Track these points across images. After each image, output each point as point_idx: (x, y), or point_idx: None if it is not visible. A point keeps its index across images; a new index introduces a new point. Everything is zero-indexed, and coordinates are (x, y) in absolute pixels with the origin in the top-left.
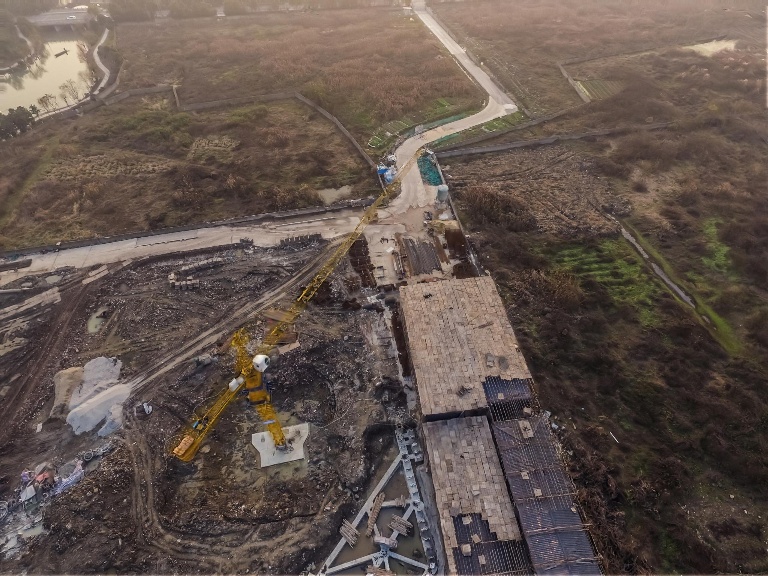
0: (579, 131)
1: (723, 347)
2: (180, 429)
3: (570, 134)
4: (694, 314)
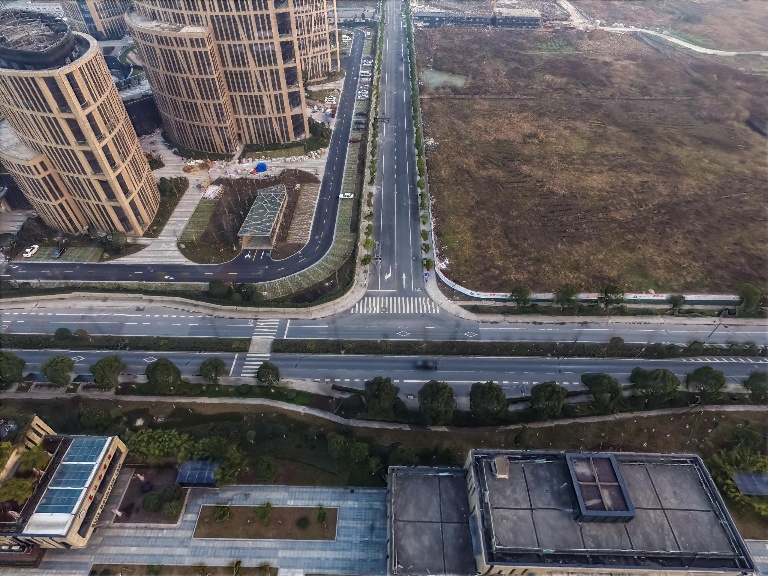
0: (678, 58)
1: (516, 49)
2: (497, 7)
3: (671, 54)
4: (531, 51)
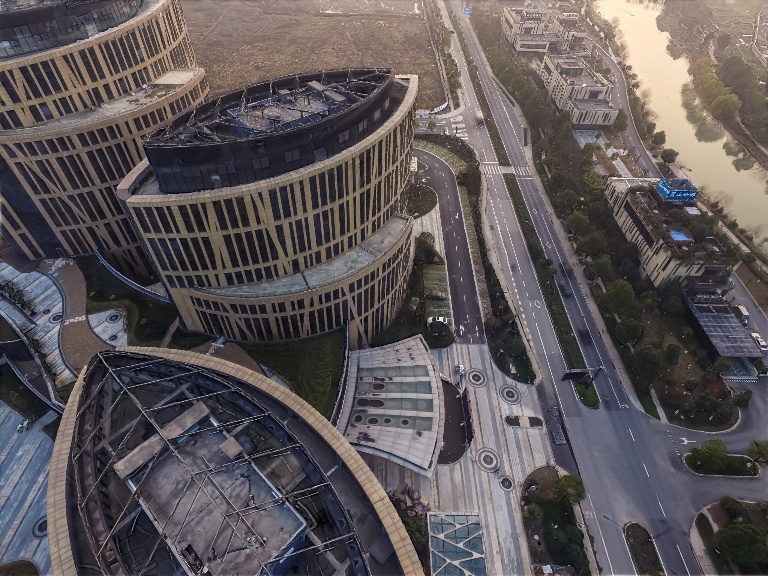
0: None
1: None
2: None
3: None
4: None
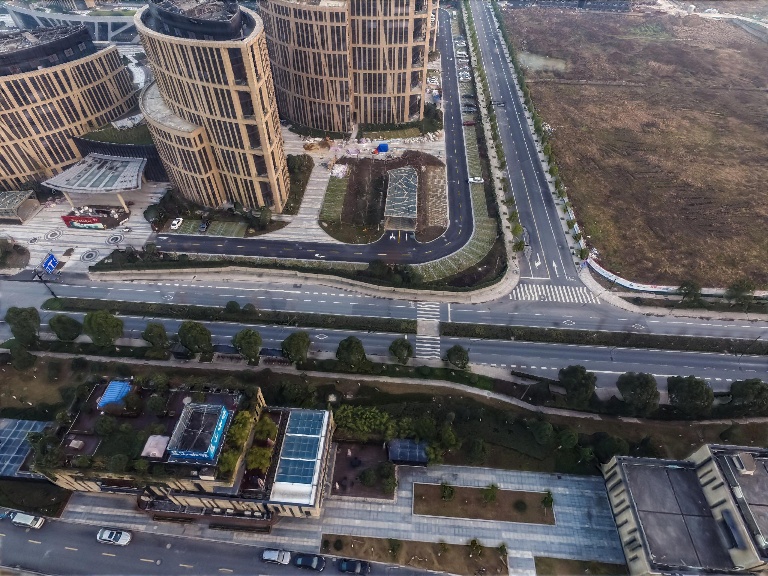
0: None
1: (609, 33)
2: None
3: None
4: (626, 36)
